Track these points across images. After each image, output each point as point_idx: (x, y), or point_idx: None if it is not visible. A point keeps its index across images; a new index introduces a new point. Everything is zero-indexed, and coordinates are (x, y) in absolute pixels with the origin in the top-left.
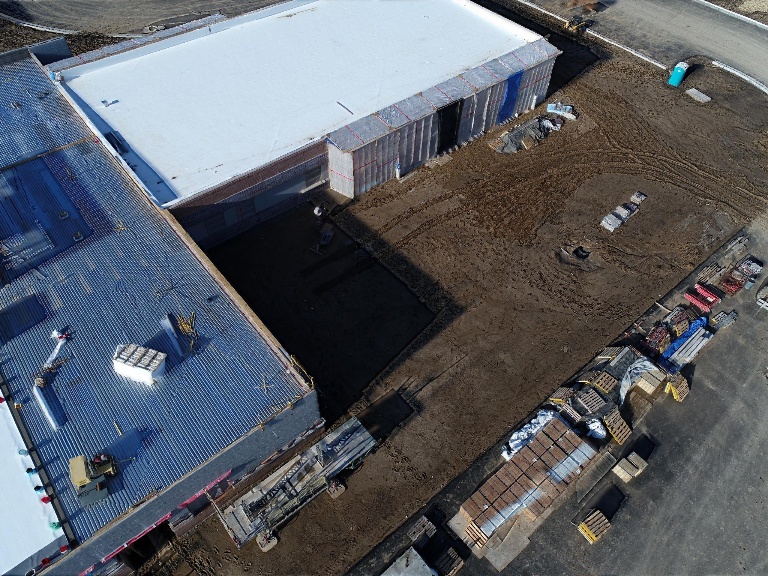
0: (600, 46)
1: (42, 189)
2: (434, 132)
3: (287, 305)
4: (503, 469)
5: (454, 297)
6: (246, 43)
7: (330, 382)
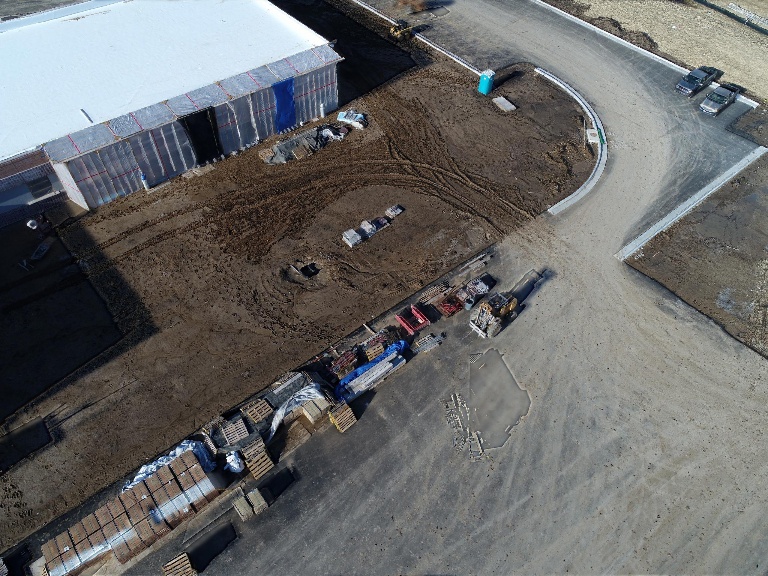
0: (423, 52)
1: None
2: (184, 141)
3: None
4: (105, 507)
5: (151, 317)
6: (16, 47)
7: None
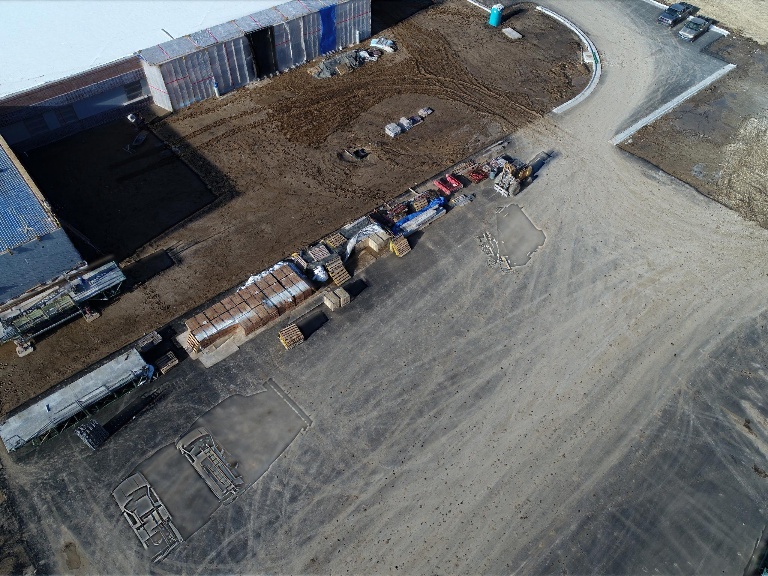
0: None
1: None
2: (248, 56)
3: (90, 190)
4: (228, 298)
5: (238, 185)
6: None
7: (110, 244)
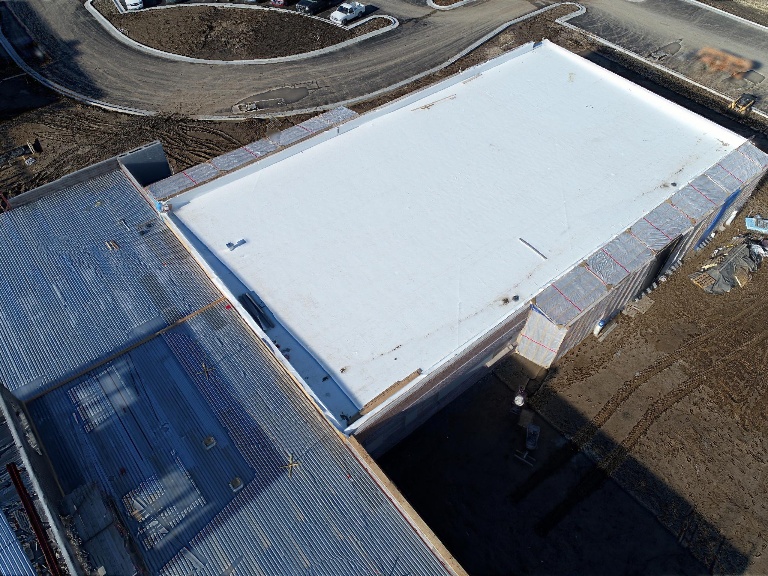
0: None
1: (171, 392)
2: None
3: (507, 556)
4: None
5: (725, 537)
6: (384, 148)
7: None
